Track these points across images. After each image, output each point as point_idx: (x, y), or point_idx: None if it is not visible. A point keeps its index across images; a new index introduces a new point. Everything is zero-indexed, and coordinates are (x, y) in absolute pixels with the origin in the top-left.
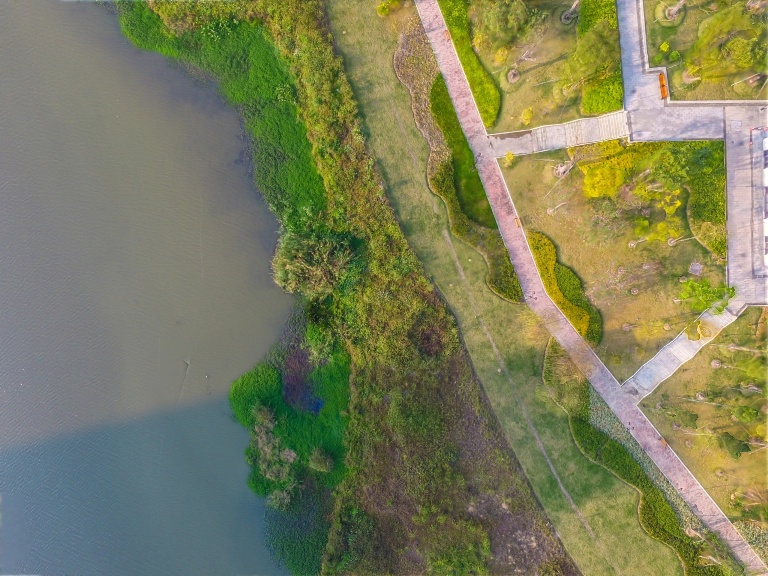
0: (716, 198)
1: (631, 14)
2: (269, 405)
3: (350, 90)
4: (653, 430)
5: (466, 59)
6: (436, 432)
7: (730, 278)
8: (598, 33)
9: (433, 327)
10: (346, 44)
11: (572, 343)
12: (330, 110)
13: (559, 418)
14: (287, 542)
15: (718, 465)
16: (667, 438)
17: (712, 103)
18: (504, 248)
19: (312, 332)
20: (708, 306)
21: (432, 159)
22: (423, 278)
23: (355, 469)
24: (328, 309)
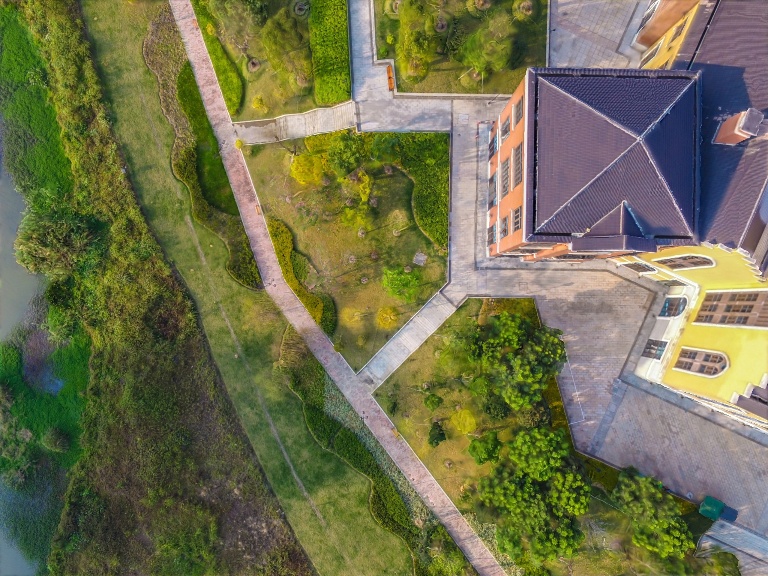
0: (438, 189)
1: (363, 7)
2: (7, 384)
3: (94, 75)
4: (387, 420)
5: (211, 48)
6: (169, 415)
7: (452, 269)
8: (276, 20)
9: (171, 311)
10: (97, 30)
11: (309, 331)
12: (76, 94)
13: (294, 405)
14: (20, 522)
15: (447, 456)
16: (399, 428)
17: (439, 96)
18: (243, 235)
19: (53, 313)
20: (396, 293)
21: (177, 145)
22: (161, 262)
23: (89, 450)
24: (69, 291)
